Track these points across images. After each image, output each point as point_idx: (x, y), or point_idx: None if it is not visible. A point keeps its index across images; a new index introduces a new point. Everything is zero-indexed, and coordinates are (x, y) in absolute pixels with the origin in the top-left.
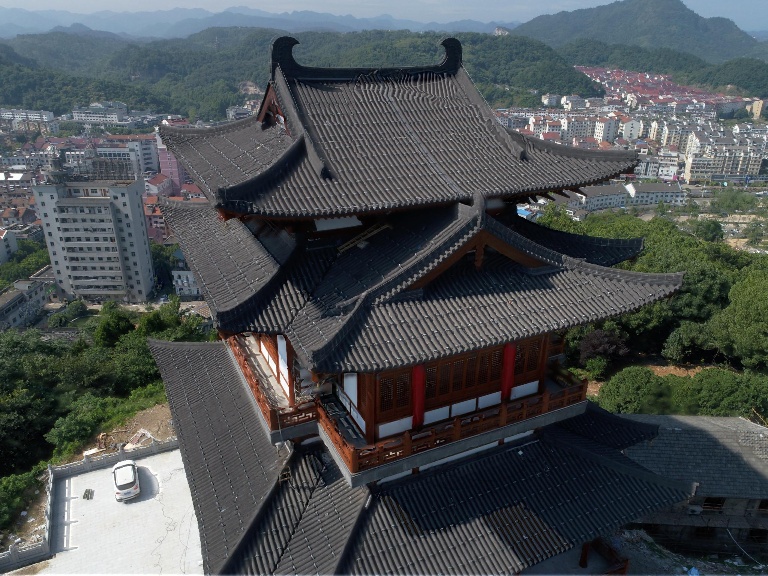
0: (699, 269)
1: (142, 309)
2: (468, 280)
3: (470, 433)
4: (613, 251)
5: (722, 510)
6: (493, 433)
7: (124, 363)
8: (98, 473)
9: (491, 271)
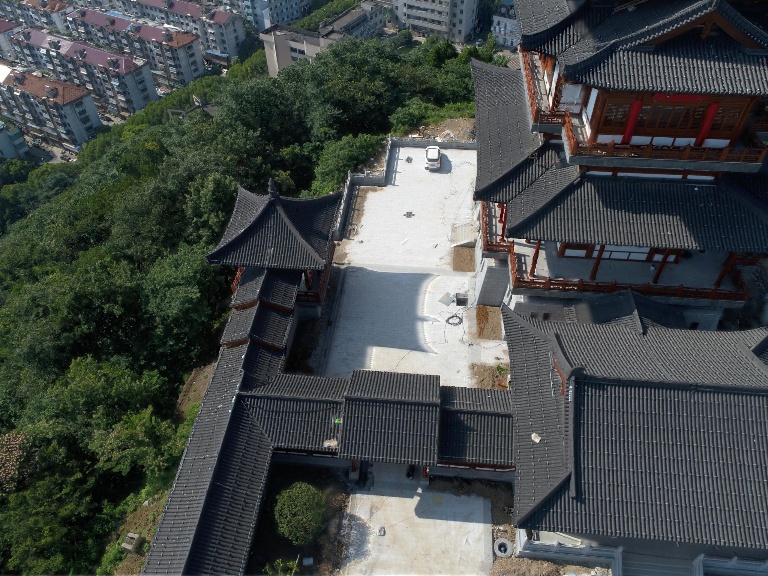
0: None
1: (458, 49)
2: (693, 47)
3: (657, 156)
4: None
5: None
6: (674, 162)
7: (445, 82)
8: (416, 149)
9: (715, 45)
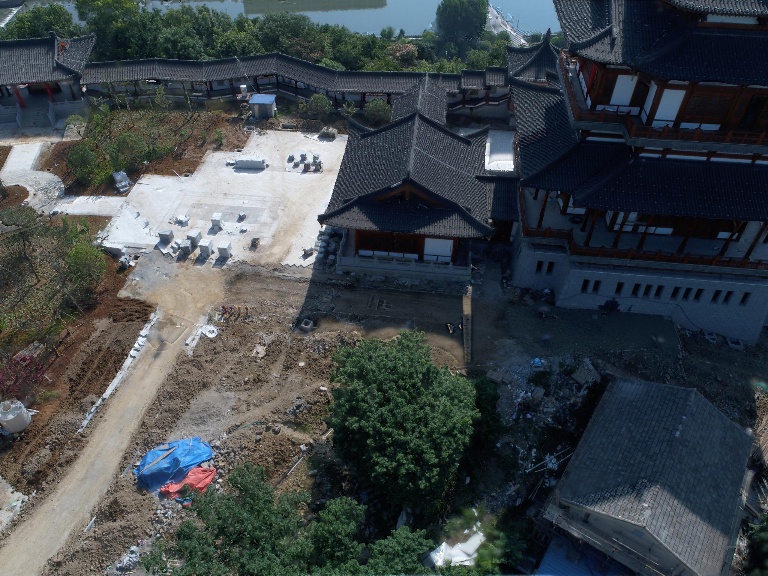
0: None
1: None
2: (603, 7)
3: None
4: None
5: None
6: None
7: None
8: None
9: None
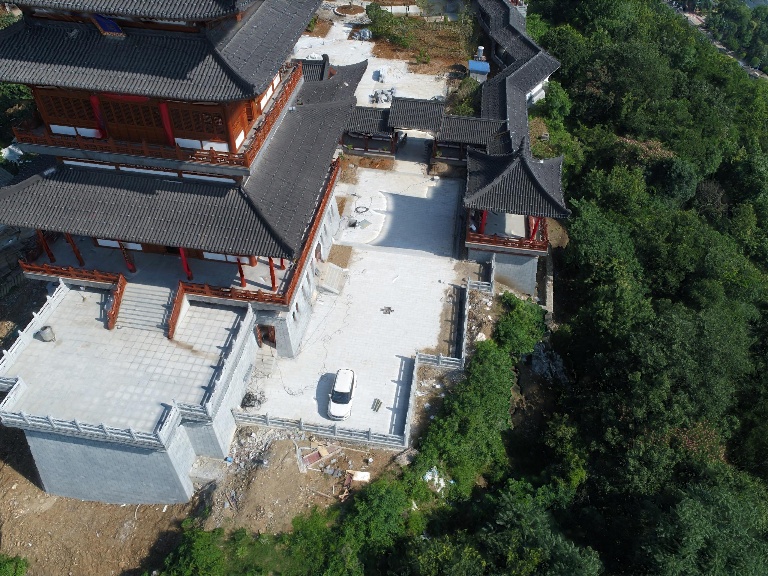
0: None
1: None
2: None
3: None
4: None
5: None
6: None
7: None
8: None
9: None
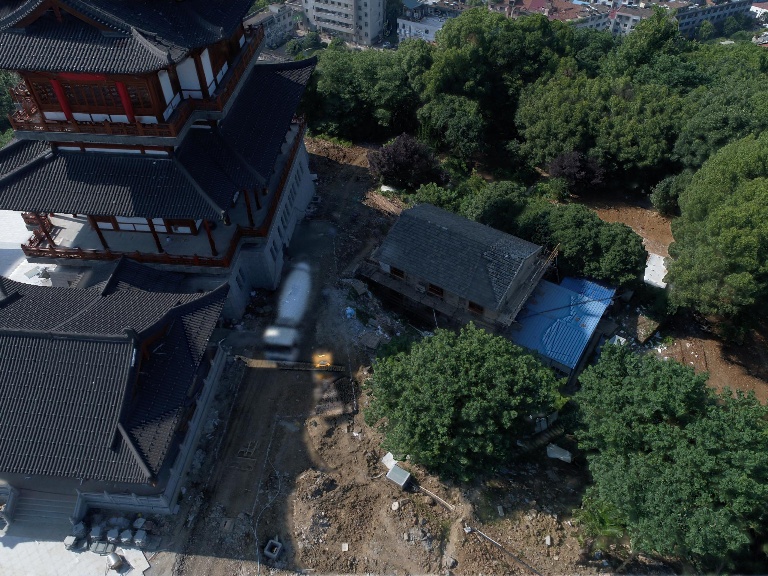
0: (721, 115)
1: None
2: (64, 30)
3: (87, 131)
4: (210, 35)
5: (443, 298)
6: (103, 136)
7: None
8: None
9: (84, 28)
